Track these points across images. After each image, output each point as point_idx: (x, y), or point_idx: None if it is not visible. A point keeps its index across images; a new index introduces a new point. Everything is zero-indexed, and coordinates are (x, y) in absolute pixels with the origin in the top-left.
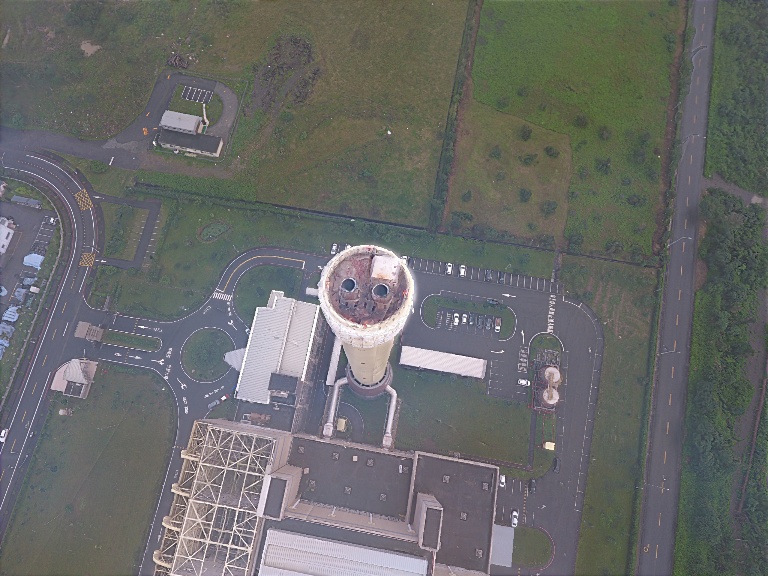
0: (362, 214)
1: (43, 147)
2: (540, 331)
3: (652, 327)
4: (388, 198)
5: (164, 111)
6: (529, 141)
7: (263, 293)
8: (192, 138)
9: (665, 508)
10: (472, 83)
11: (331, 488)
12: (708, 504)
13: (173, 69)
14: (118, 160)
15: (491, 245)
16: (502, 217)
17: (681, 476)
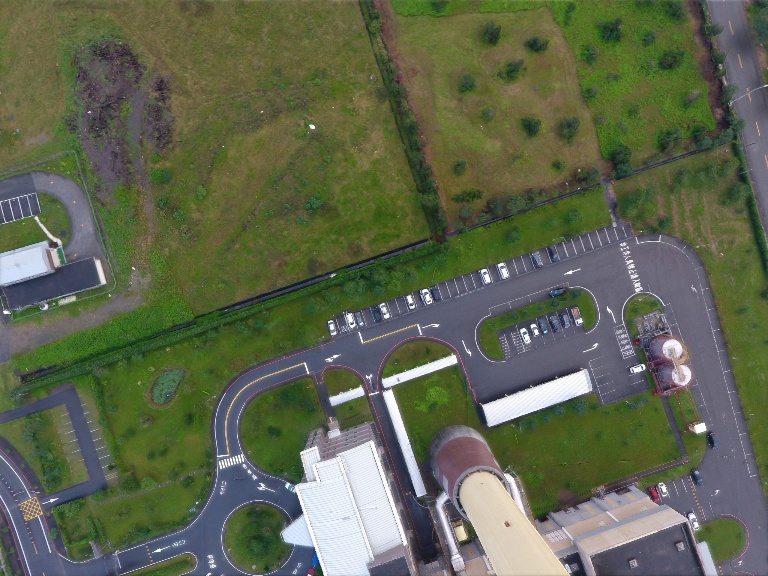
0: (341, 262)
1: None
2: (628, 296)
3: (754, 223)
4: (362, 223)
5: None
6: (500, 42)
7: (279, 432)
8: (53, 279)
9: None
10: None
11: None
12: None
13: None
14: None
15: (521, 217)
16: (516, 172)
17: None
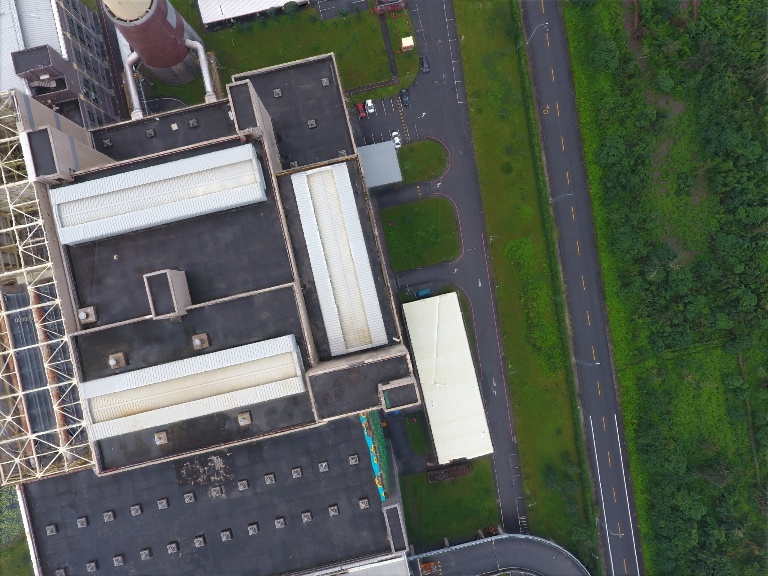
0: None
1: None
2: None
3: None
4: None
5: None
6: None
7: None
8: None
9: (556, 60)
10: None
11: None
12: (598, 30)
13: None
14: None
15: None
16: None
17: (564, 18)
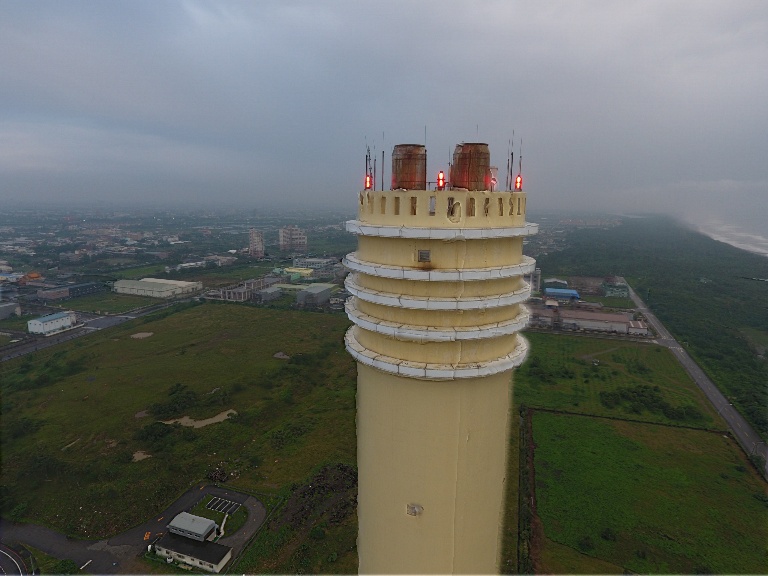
0: None
1: (21, 541)
2: None
3: None
4: None
5: None
6: None
7: None
8: (197, 545)
9: None
10: (540, 522)
11: None
12: None
13: (210, 482)
14: (94, 564)
15: None
16: None
17: None
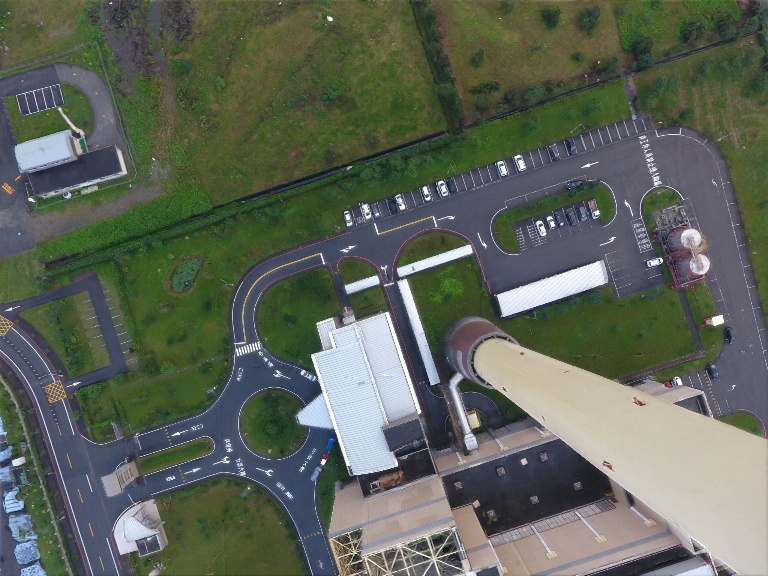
0: (357, 154)
1: None
2: (646, 190)
3: None
4: (378, 114)
5: (12, 147)
6: None
7: (295, 320)
8: (76, 166)
9: None
10: None
11: (514, 507)
12: None
13: None
14: (1, 247)
15: (538, 110)
16: (534, 64)
17: None
